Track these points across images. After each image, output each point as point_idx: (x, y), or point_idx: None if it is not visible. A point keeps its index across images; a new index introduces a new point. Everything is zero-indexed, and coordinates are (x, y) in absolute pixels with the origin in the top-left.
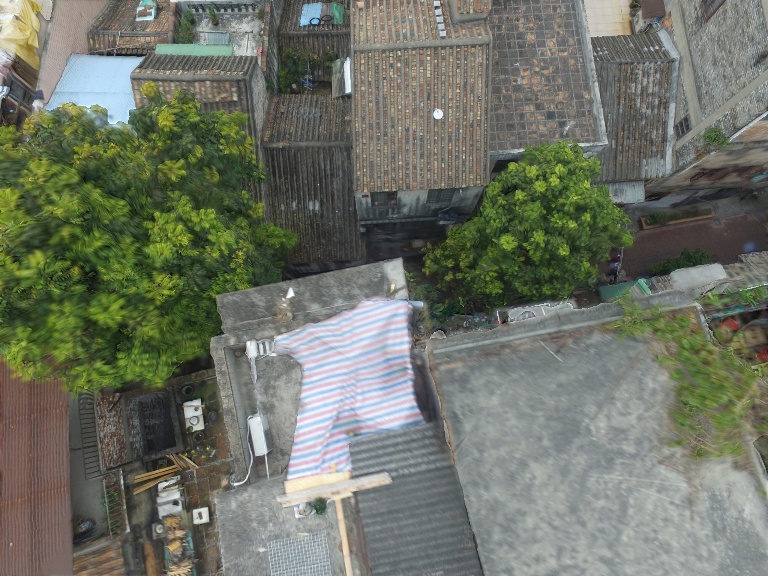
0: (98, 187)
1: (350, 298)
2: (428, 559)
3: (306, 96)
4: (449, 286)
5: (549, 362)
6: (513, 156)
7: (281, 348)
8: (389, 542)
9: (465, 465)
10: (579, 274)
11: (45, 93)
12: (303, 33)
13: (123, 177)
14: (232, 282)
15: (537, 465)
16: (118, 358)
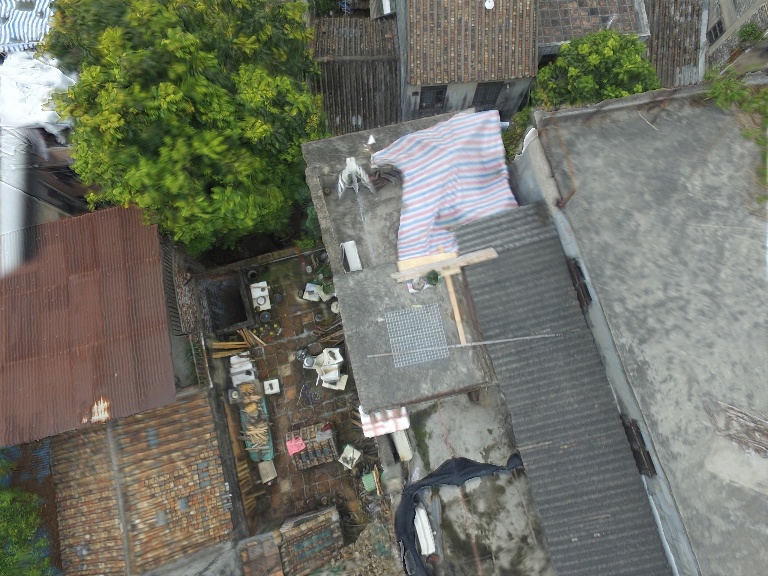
0: None
1: None
2: (535, 319)
3: (345, 19)
4: None
5: (646, 131)
6: None
7: (380, 160)
8: (498, 308)
9: (576, 214)
10: None
11: None
12: None
13: (209, 35)
14: None
15: (641, 215)
16: (213, 198)
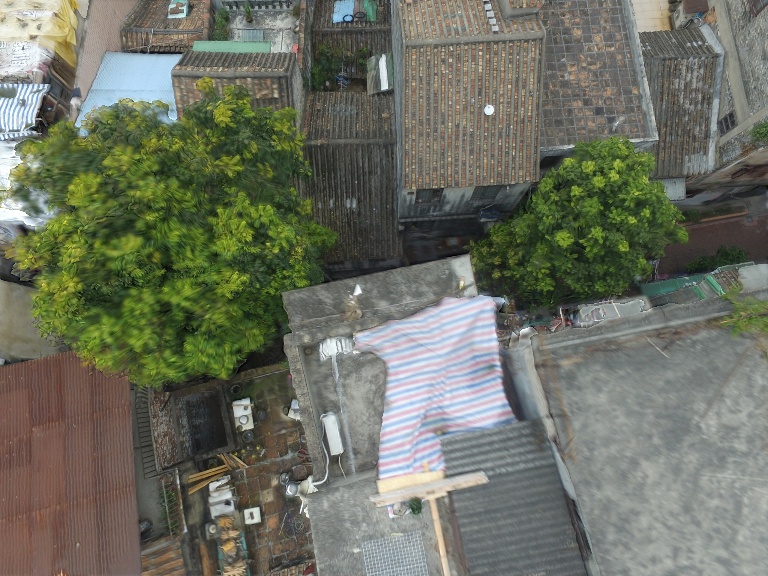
0: (162, 183)
1: (418, 295)
2: (529, 560)
3: (341, 93)
4: (491, 284)
5: (656, 359)
6: (562, 152)
7: (363, 345)
8: (487, 542)
9: (576, 464)
10: (635, 271)
11: (82, 91)
12: (337, 30)
13: (187, 173)
14: (291, 279)
15: (649, 464)
16: (186, 356)
